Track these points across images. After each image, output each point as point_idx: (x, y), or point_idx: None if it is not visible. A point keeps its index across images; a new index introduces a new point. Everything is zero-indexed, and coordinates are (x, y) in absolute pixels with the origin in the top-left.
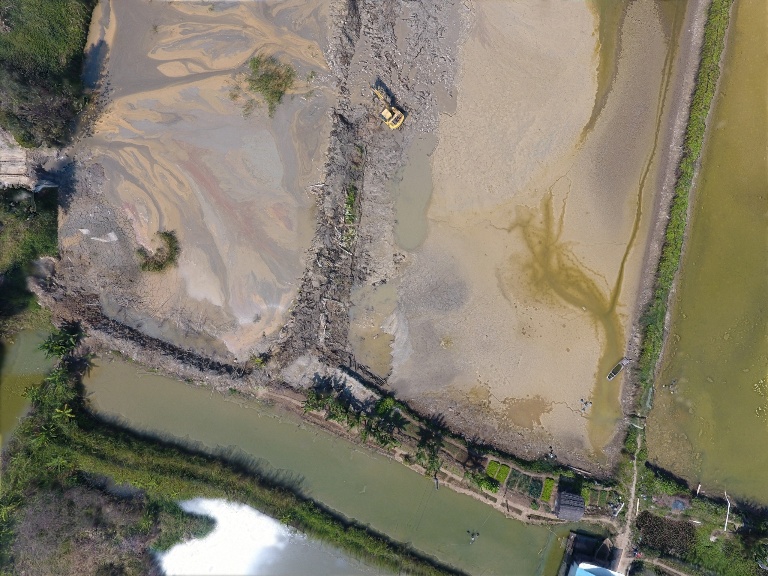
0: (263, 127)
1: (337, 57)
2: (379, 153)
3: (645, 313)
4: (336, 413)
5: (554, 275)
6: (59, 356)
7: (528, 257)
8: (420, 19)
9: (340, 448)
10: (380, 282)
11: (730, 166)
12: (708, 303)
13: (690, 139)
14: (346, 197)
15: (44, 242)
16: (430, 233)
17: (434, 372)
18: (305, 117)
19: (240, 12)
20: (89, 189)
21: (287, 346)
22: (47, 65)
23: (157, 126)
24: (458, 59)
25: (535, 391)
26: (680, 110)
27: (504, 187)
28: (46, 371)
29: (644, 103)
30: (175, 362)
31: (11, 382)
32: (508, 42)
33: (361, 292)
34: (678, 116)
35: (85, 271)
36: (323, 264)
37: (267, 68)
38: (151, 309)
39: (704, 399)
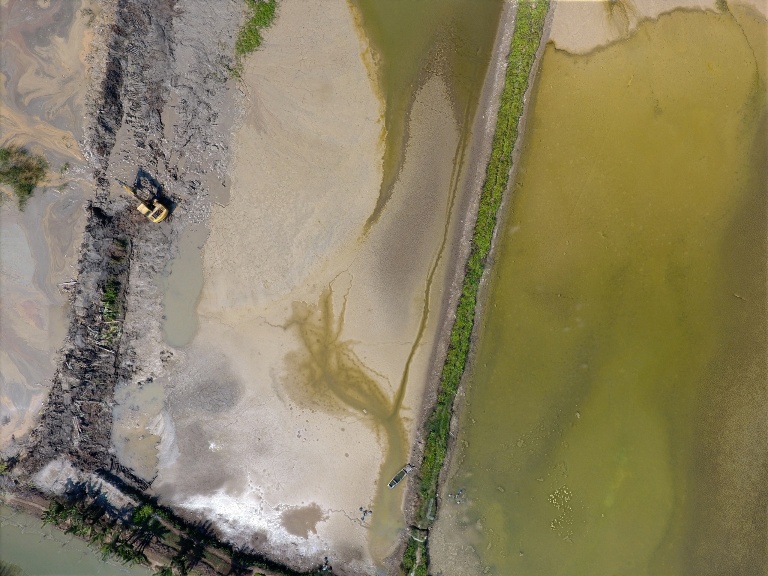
0: (13, 221)
1: (94, 148)
2: (146, 246)
3: (429, 418)
4: (78, 526)
5: (333, 375)
6: None
7: (305, 356)
8: (189, 105)
9: None
10: (146, 381)
11: (526, 261)
12: (500, 407)
13: (477, 235)
14: (103, 294)
15: None
16: (200, 330)
17: (202, 476)
18: (58, 211)
19: None
20: None
21: (34, 451)
22: None
23: None
24: (232, 147)
25: (311, 498)
26: (472, 202)
27: (280, 282)
28: None
29: (433, 194)
30: None
31: None
32: (286, 129)
33: (126, 391)
34: (470, 208)
35: None
36: (74, 366)
37: (18, 160)
38: None
39: (494, 510)
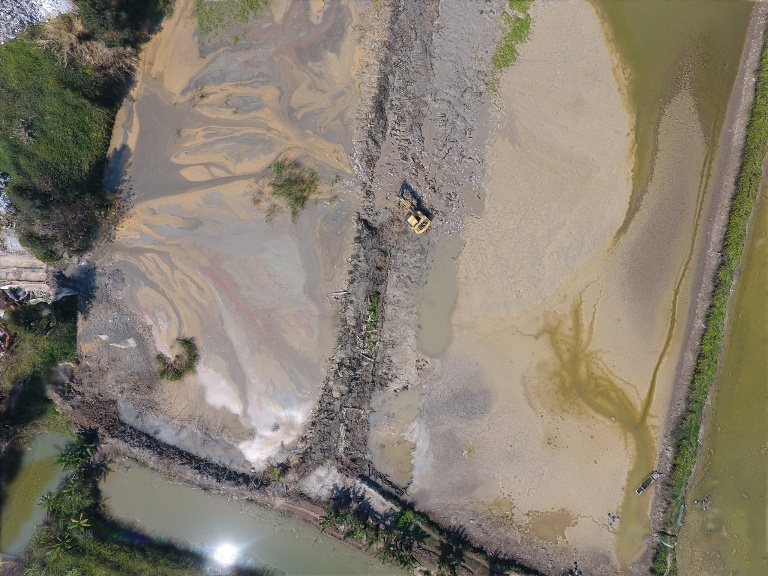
0: (286, 232)
1: (363, 161)
2: (403, 256)
3: (678, 426)
4: (355, 531)
5: (582, 384)
6: (76, 466)
7: (556, 365)
8: (448, 119)
9: (357, 560)
10: (402, 388)
11: None
12: (745, 416)
13: (729, 246)
14: (369, 304)
15: (63, 349)
16: (454, 339)
17: (456, 482)
18: (329, 222)
19: (265, 115)
20: (109, 295)
21: (306, 458)
22: (70, 173)
23: (178, 231)
24: (487, 160)
25: (560, 504)
26: (719, 214)
27: (532, 292)
28: (62, 475)
29: (681, 206)
30: (192, 472)
31: (27, 486)
32: (539, 142)
33: (382, 398)
34: (717, 220)
35: (103, 376)
36: (344, 374)
37: (291, 172)
38: (168, 416)
39: (738, 516)
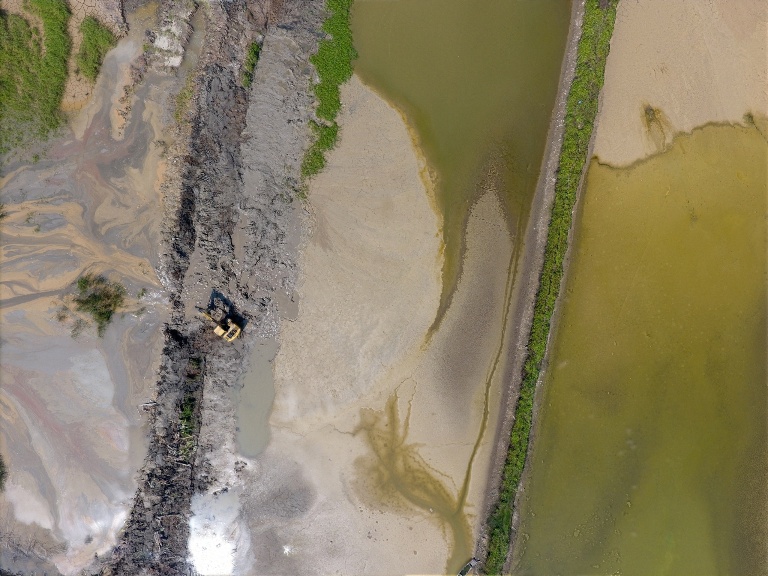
0: (93, 346)
1: (169, 273)
2: (219, 361)
3: (492, 514)
4: None
5: (400, 478)
6: None
7: (373, 460)
8: (258, 227)
9: None
10: (221, 491)
11: (578, 362)
12: (557, 500)
13: (533, 342)
14: (181, 412)
15: None
16: (272, 440)
17: None
18: (136, 335)
19: (68, 231)
20: None
21: (118, 569)
22: None
23: None
24: (299, 264)
25: None
26: (526, 309)
27: (348, 391)
28: None
29: (490, 302)
30: None
31: None
32: (350, 246)
33: (202, 501)
34: (524, 314)
35: None
36: (155, 484)
37: (96, 287)
38: None
39: None
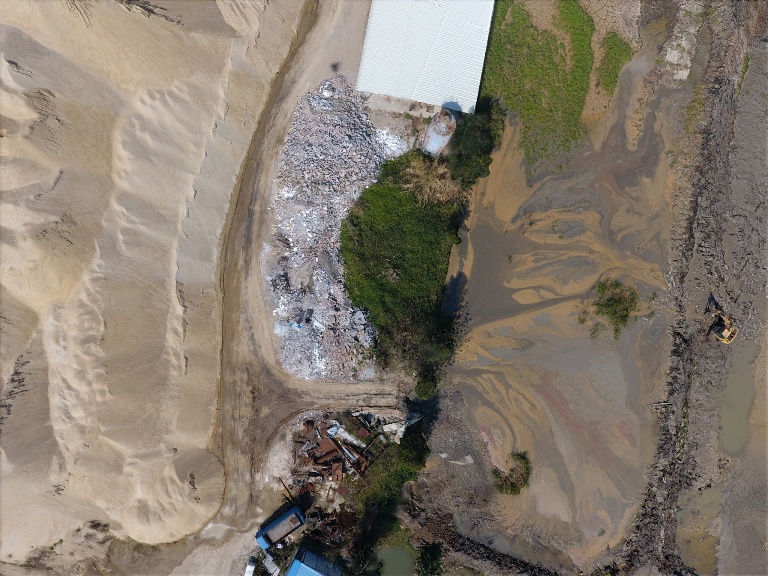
0: (608, 348)
1: (676, 278)
2: (705, 363)
3: None
4: None
5: None
6: None
7: None
8: (746, 234)
9: None
10: (706, 487)
11: None
12: None
13: None
14: None
15: (410, 470)
16: (752, 438)
17: (757, 573)
18: (647, 337)
19: (587, 238)
20: (449, 415)
21: (634, 561)
22: (422, 305)
23: (512, 352)
24: None
25: None
26: None
27: None
28: None
29: None
30: None
31: None
32: None
33: (687, 497)
34: None
35: (440, 491)
36: (666, 480)
37: (613, 292)
38: (502, 526)
39: None
